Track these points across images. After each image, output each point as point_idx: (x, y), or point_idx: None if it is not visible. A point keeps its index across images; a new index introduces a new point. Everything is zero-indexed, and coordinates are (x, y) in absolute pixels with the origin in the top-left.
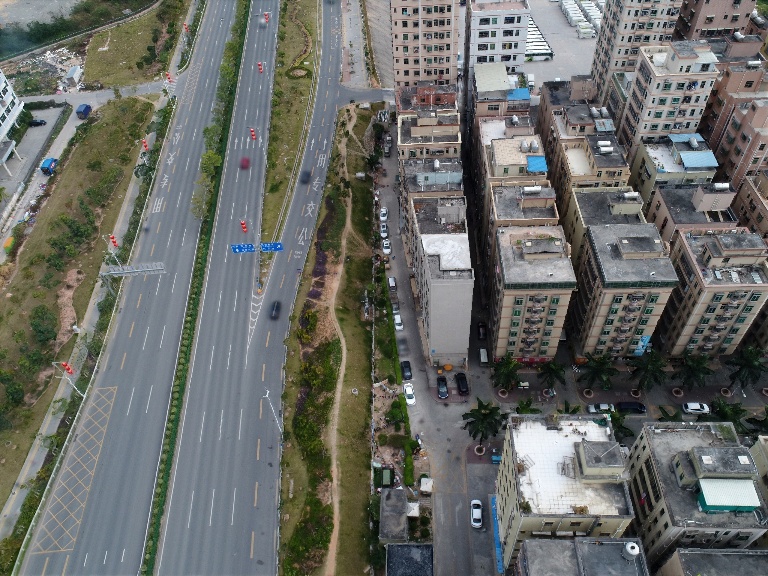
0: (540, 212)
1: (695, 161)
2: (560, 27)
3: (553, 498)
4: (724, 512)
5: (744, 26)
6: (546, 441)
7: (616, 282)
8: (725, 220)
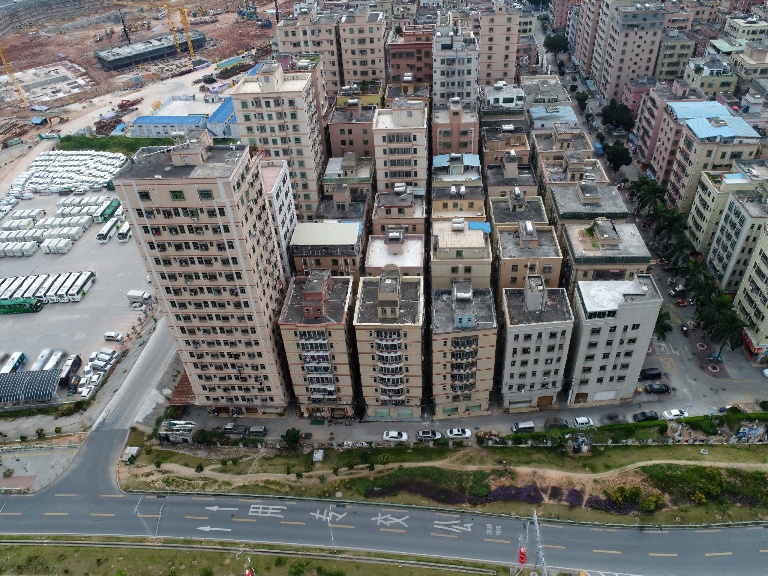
0: (540, 237)
1: (474, 161)
2: (22, 265)
3: None
4: None
5: (327, 101)
6: None
7: None
8: (526, 170)
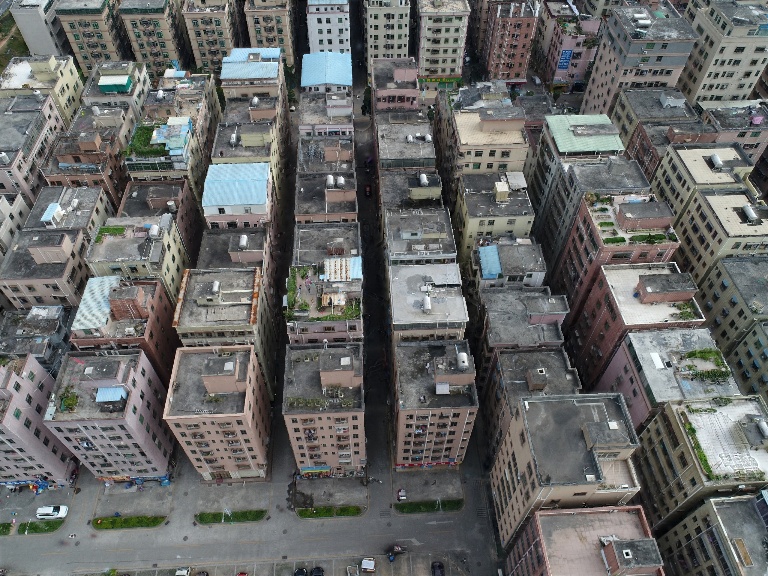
0: None
1: None
2: None
3: (17, 86)
4: (114, 93)
5: None
6: (30, 68)
7: (124, 9)
8: None
